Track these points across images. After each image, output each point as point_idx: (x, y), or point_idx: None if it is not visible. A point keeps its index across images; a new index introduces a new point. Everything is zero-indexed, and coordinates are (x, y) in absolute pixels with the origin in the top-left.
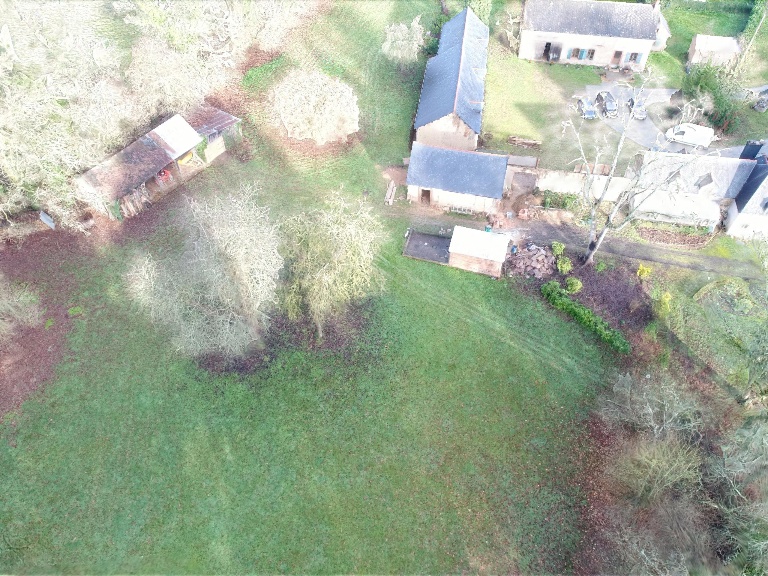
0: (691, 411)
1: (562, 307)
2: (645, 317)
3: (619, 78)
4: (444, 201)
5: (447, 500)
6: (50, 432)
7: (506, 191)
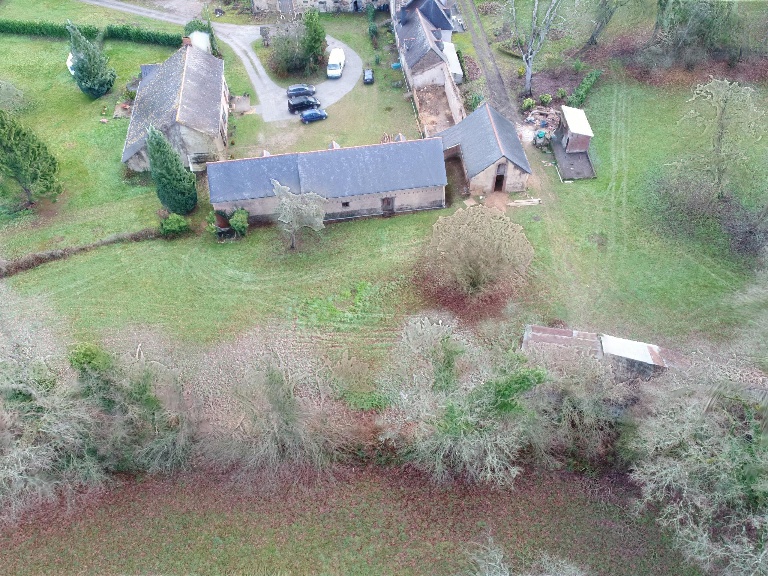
0: None
1: None
2: None
3: (247, 103)
4: None
5: (761, 122)
6: None
7: None
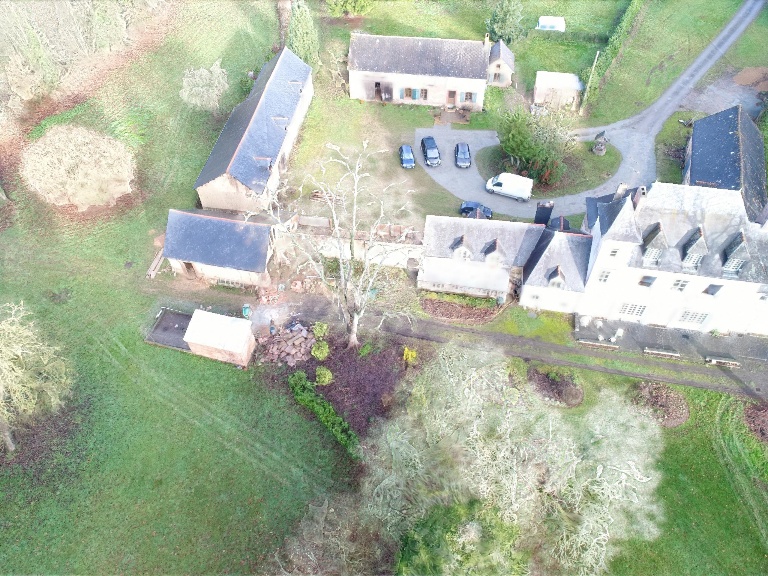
0: (329, 575)
1: (304, 403)
2: (399, 412)
3: (453, 119)
4: (210, 273)
5: None
6: None
7: (283, 260)
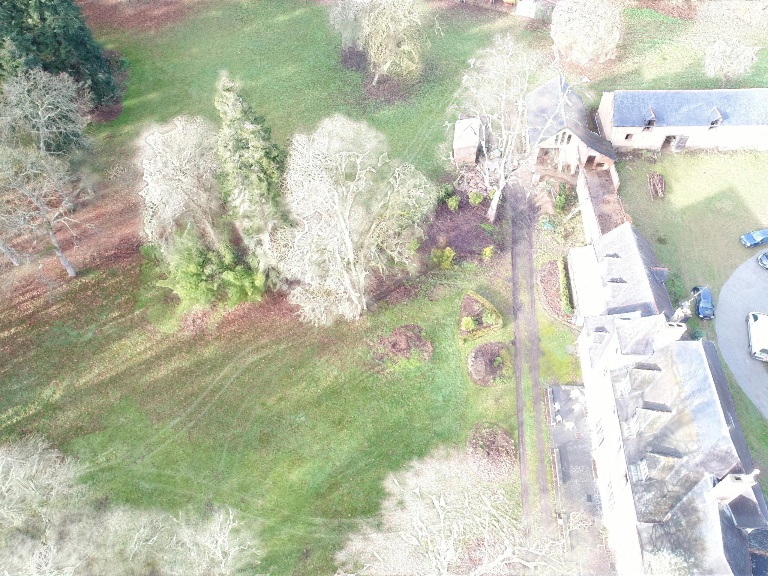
0: None
1: None
2: None
3: None
4: None
5: None
6: (297, 12)
7: (558, 163)
